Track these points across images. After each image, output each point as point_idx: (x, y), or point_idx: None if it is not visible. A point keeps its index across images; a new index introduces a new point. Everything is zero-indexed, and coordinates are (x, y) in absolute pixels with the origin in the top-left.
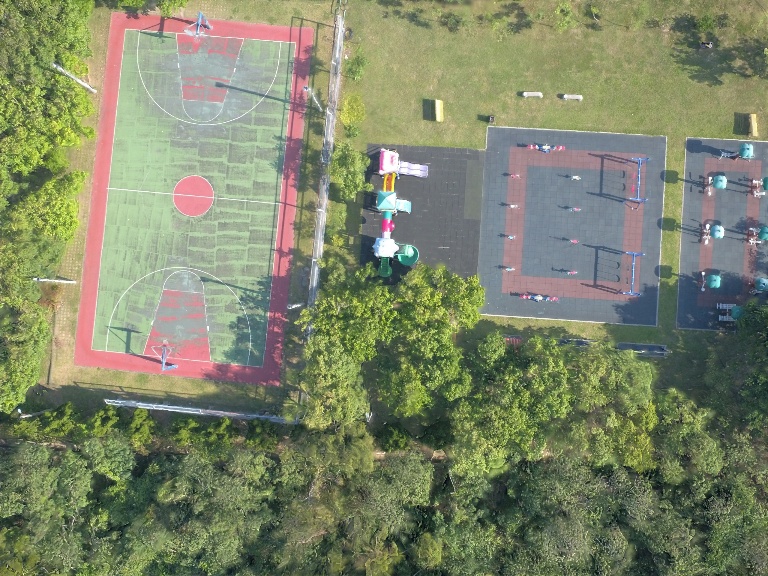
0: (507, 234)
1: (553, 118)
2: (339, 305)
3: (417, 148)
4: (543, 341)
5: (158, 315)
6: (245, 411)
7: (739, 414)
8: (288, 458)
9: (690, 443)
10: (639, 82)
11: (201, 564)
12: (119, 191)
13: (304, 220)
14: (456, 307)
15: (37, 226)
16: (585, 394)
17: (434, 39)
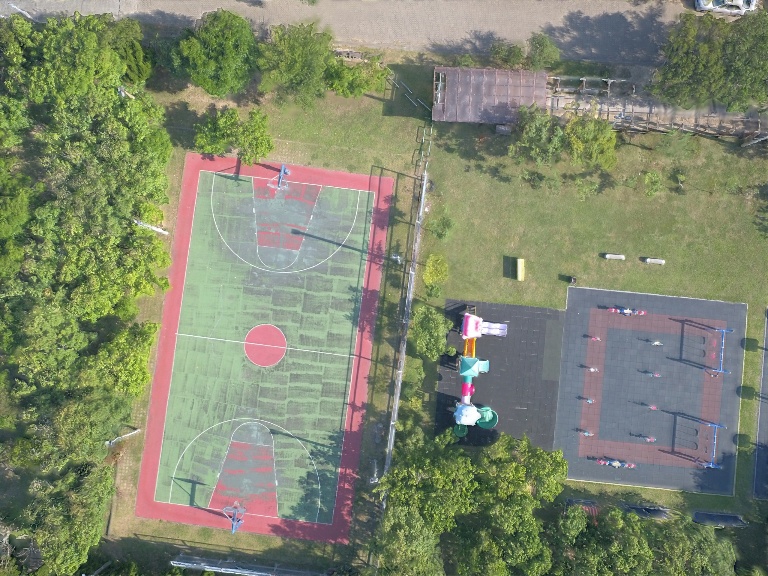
0: (585, 397)
1: (634, 281)
2: (420, 475)
3: (496, 306)
4: (625, 515)
5: (225, 467)
6: (312, 570)
7: None
8: None
9: None
10: (721, 248)
11: None
12: (188, 337)
13: (379, 374)
14: (540, 482)
15: (108, 382)
16: None
17: (516, 196)
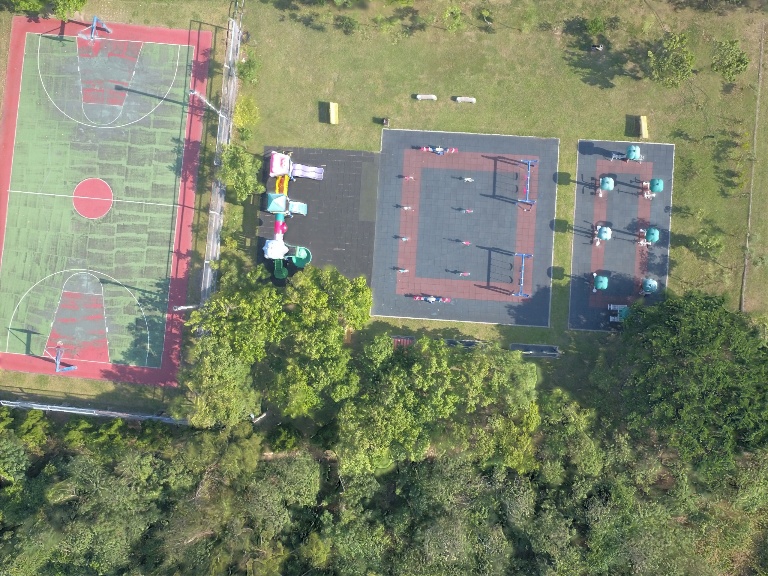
0: (401, 236)
1: (447, 120)
2: (228, 307)
3: (313, 150)
4: (431, 342)
5: (58, 317)
6: (143, 412)
7: (619, 414)
8: (177, 458)
9: (569, 443)
10: (532, 85)
11: (92, 564)
12: (20, 194)
13: (202, 222)
14: (343, 308)
15: None
16: (466, 395)
17: (330, 42)
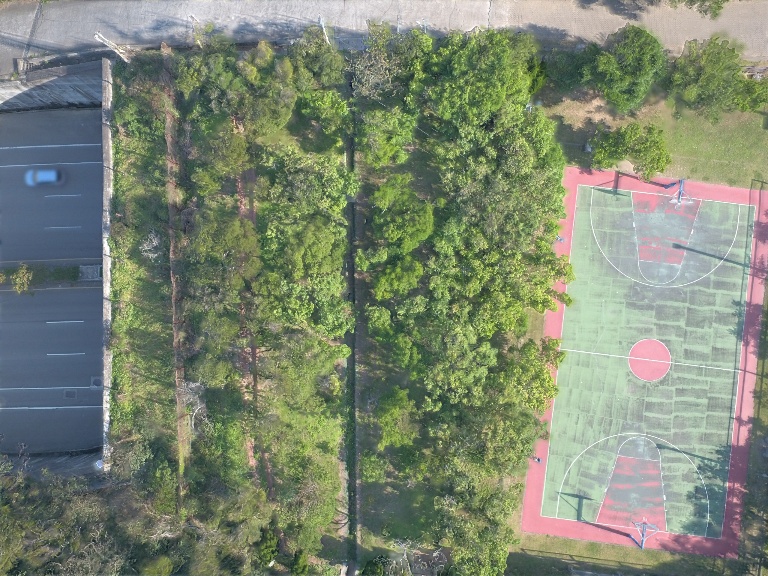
0: None
1: None
2: None
3: None
4: None
5: (612, 482)
6: None
7: None
8: None
9: None
10: None
11: None
12: (571, 352)
13: (765, 389)
14: None
15: (523, 399)
16: None
17: None
